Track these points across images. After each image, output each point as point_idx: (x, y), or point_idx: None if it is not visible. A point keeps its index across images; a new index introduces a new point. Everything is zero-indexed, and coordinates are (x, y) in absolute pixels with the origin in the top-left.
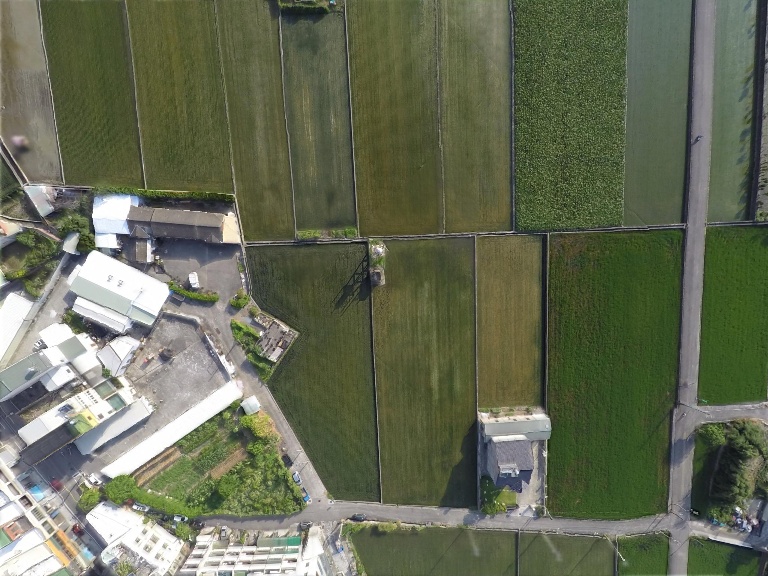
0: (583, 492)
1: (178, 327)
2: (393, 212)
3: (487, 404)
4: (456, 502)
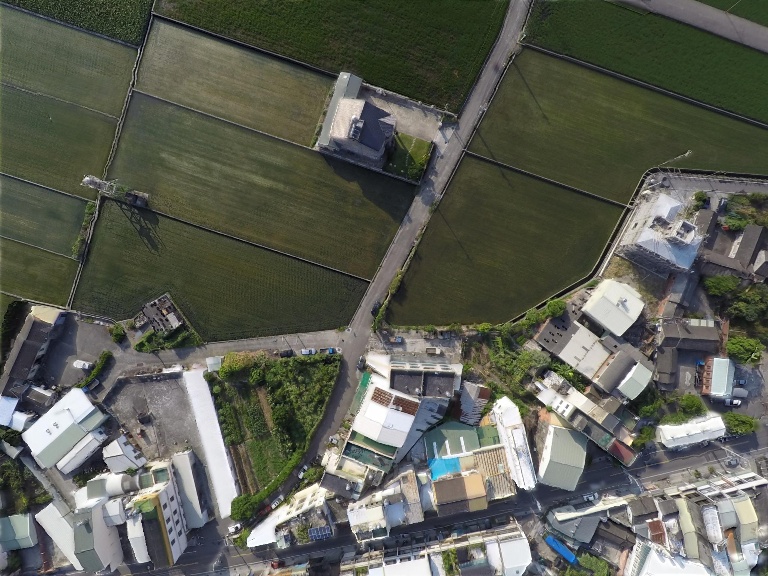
0: (447, 64)
1: (123, 397)
2: (84, 162)
3: (309, 137)
4: (403, 206)
